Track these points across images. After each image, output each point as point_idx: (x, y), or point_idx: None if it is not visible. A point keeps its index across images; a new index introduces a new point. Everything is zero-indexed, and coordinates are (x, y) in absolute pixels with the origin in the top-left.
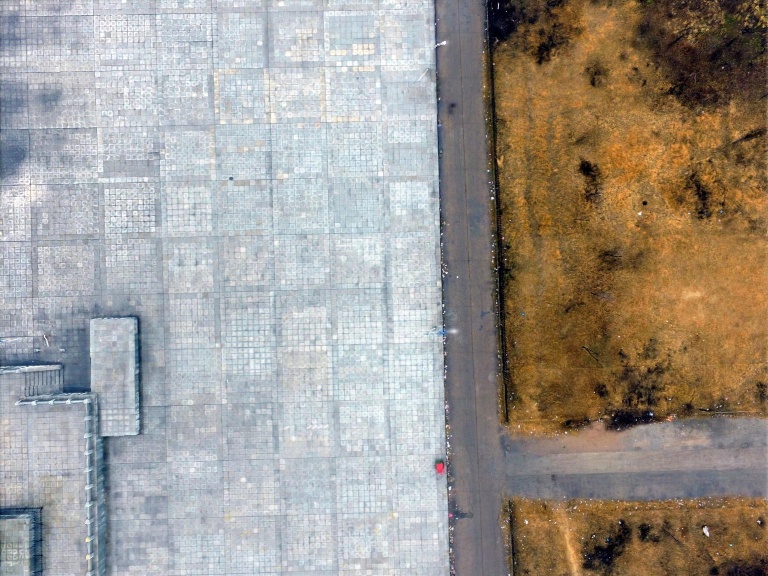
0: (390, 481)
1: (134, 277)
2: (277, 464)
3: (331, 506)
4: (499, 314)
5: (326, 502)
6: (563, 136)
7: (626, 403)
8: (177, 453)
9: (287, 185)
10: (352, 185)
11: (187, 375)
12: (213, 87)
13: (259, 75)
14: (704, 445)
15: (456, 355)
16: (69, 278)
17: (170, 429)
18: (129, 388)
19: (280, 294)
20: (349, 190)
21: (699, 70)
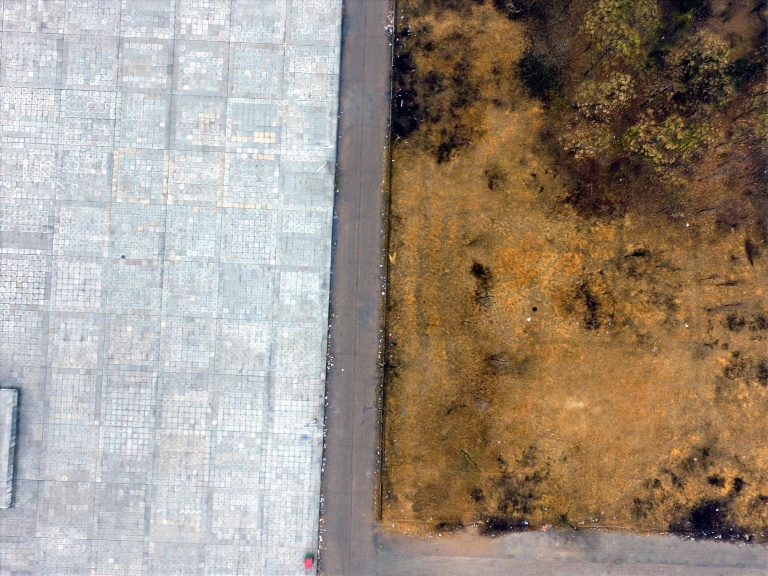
0: (259, 572)
1: (18, 349)
2: (146, 547)
3: None
4: (381, 410)
5: None
6: (457, 237)
7: (502, 510)
8: (47, 529)
9: (178, 267)
10: (243, 271)
11: (63, 451)
12: (112, 165)
13: (159, 156)
14: (578, 558)
15: (335, 448)
16: None
17: (42, 504)
18: (2, 461)
19: (163, 375)
20: (240, 276)
21: (596, 181)
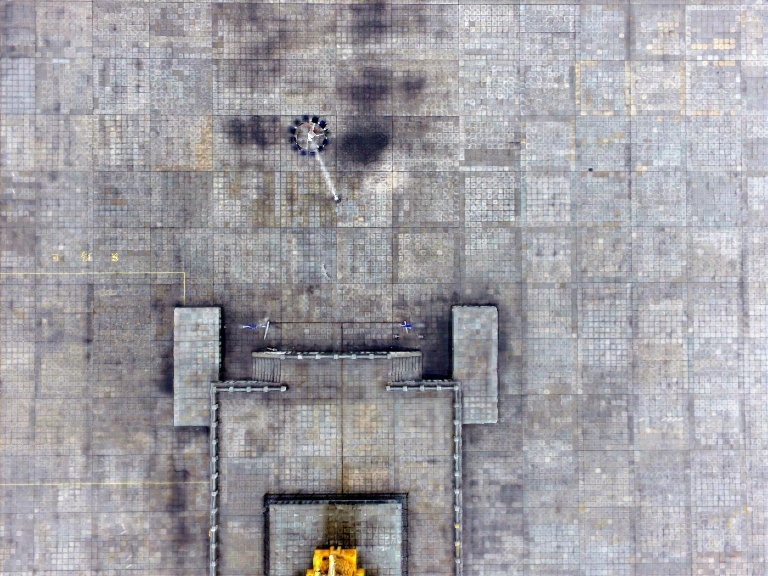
0: (744, 475)
1: (493, 266)
2: (632, 455)
3: (685, 499)
4: None
5: (680, 495)
6: None
7: None
8: (533, 442)
9: (646, 177)
10: (710, 179)
11: (544, 364)
12: (574, 78)
13: (620, 67)
14: None
15: None
16: (429, 265)
17: (526, 418)
18: (492, 376)
19: (637, 286)
20: (707, 184)
21: None
